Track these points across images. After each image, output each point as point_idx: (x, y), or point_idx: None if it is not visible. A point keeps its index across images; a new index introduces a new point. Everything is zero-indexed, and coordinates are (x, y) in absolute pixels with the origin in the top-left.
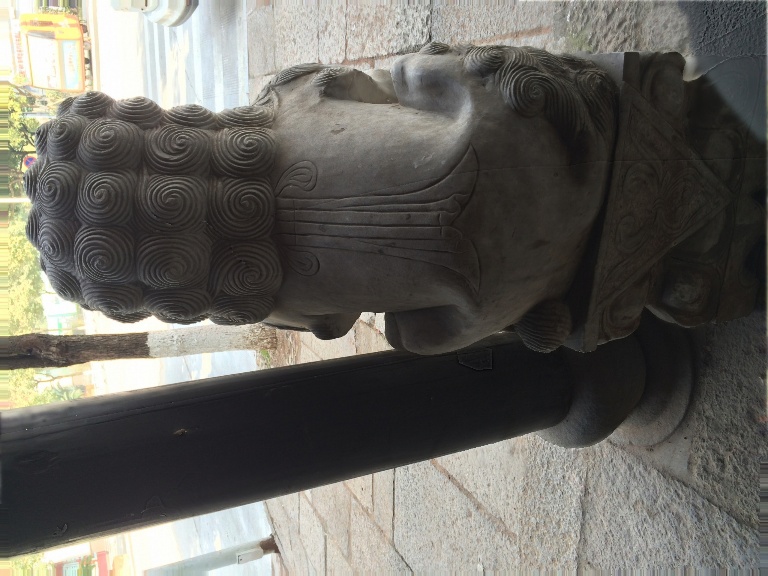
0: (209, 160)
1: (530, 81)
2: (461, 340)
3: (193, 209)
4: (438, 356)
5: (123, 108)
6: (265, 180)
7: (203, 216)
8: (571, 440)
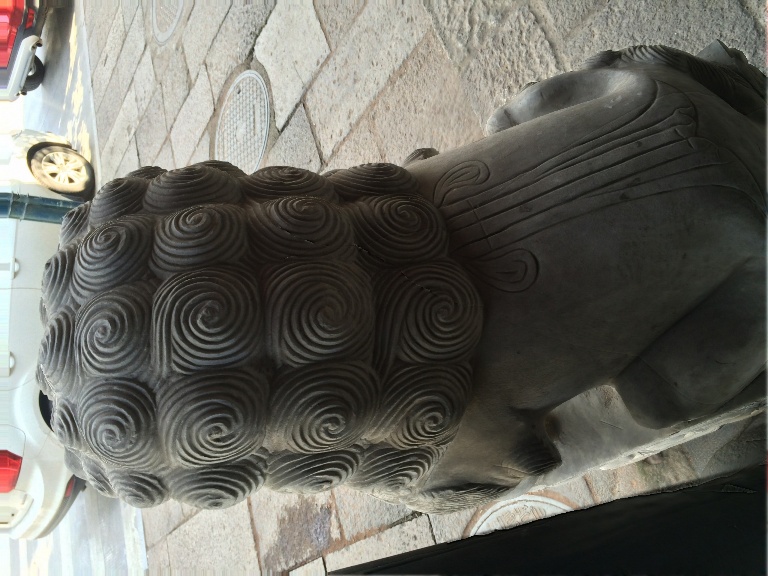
0: (334, 189)
1: None
2: None
3: (338, 223)
4: (683, 492)
5: (199, 163)
6: (416, 195)
7: (352, 236)
8: None
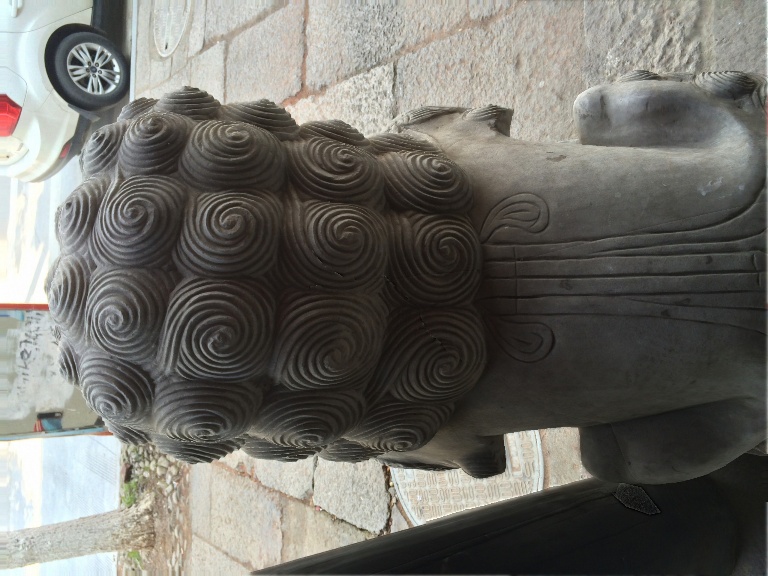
0: (383, 188)
1: None
2: (734, 454)
3: (375, 253)
4: (598, 498)
5: (249, 108)
6: (465, 219)
7: (384, 267)
8: None
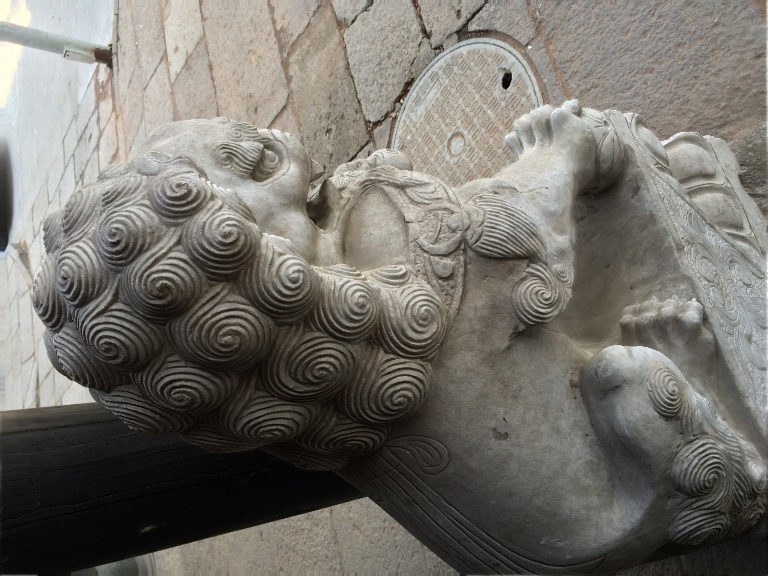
0: (338, 391)
1: (707, 532)
2: None
3: None
4: None
5: (267, 295)
6: (386, 430)
7: None
8: None
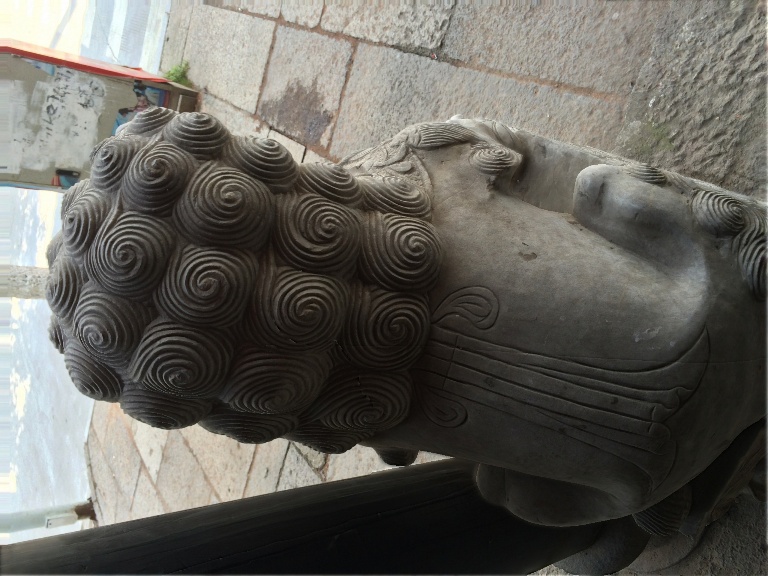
0: (357, 257)
1: None
2: None
3: (330, 326)
4: None
5: (251, 156)
6: (423, 299)
7: (336, 334)
8: (582, 571)
